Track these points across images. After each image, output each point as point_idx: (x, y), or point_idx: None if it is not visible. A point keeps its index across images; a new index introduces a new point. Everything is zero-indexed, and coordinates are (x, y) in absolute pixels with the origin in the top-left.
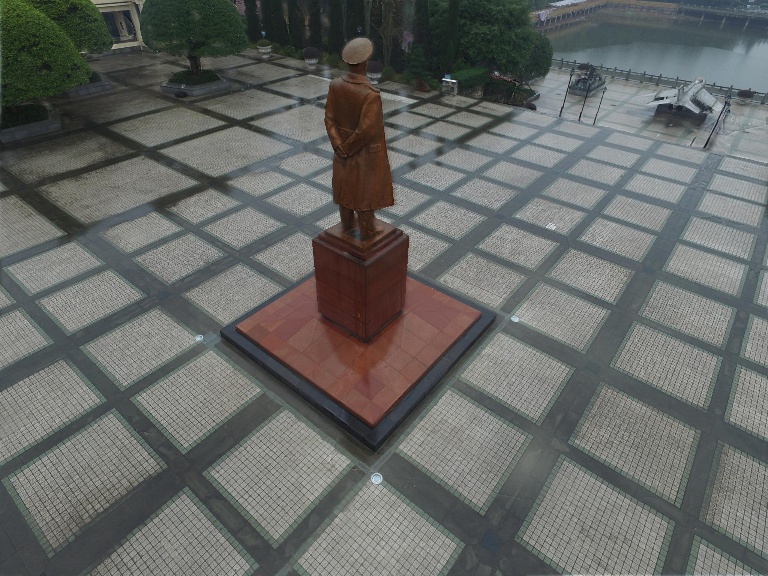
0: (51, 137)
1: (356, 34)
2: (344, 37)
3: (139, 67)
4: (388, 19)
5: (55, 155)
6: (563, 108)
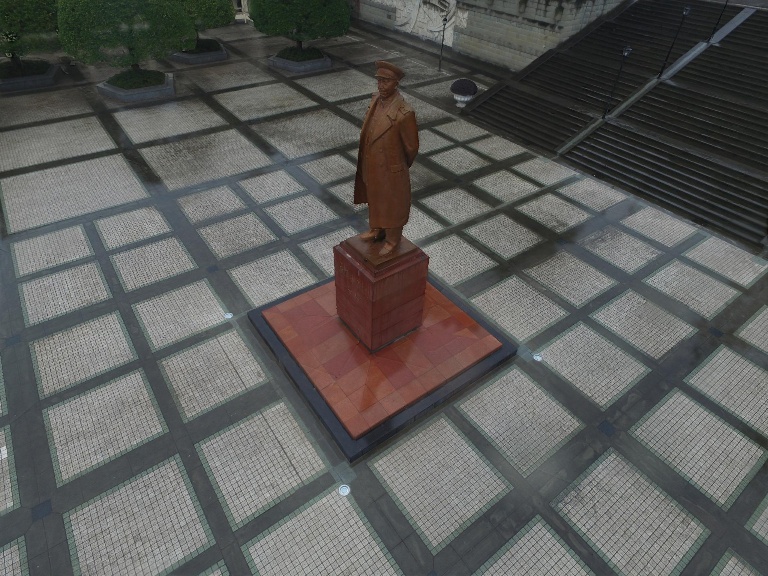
0: None
1: None
2: None
3: None
4: None
5: None
6: None
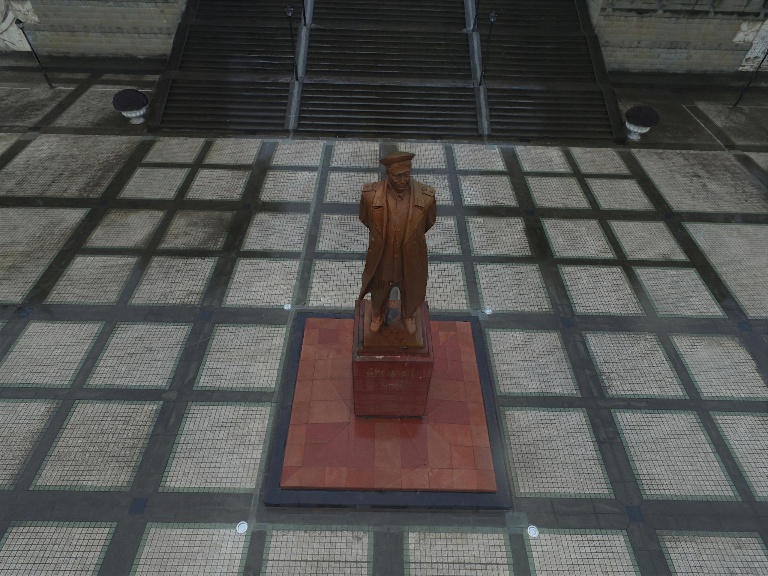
0: None
1: None
2: None
3: None
4: None
5: None
6: None
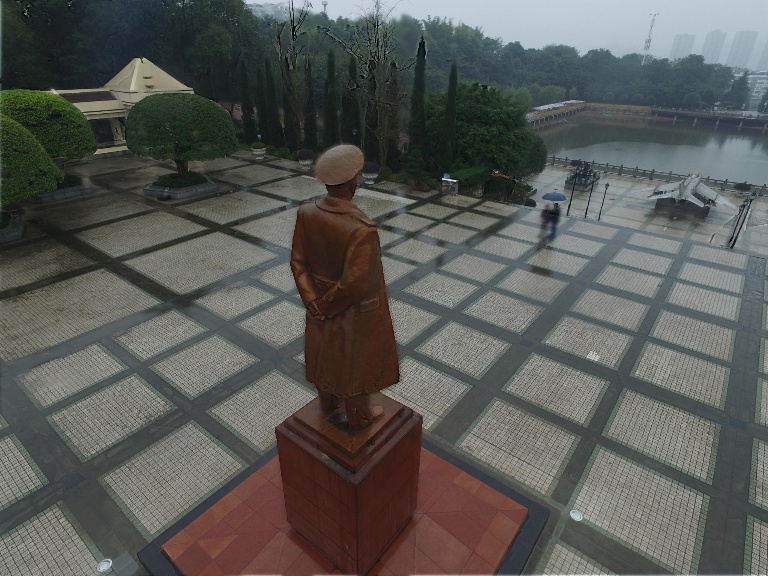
0: (6, 247)
1: (351, 136)
2: (339, 139)
3: (127, 170)
4: (384, 122)
5: (1, 269)
6: (570, 206)
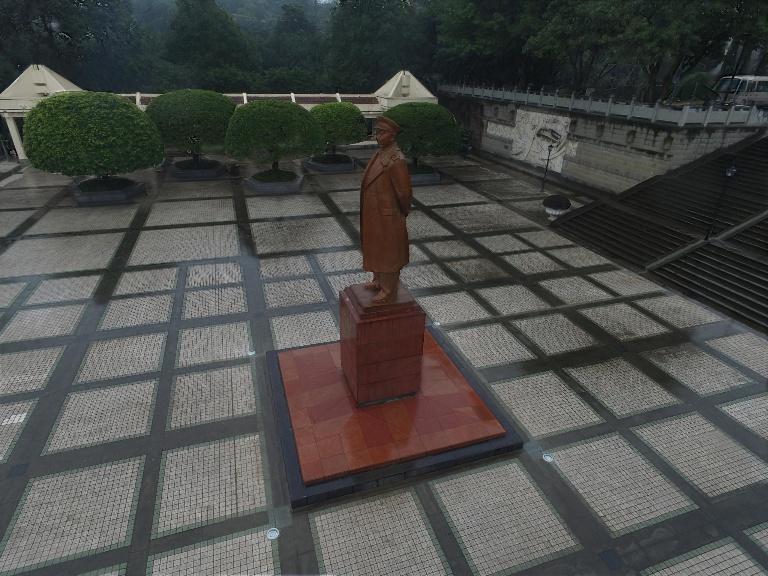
0: None
1: None
2: None
3: None
4: None
5: None
6: None
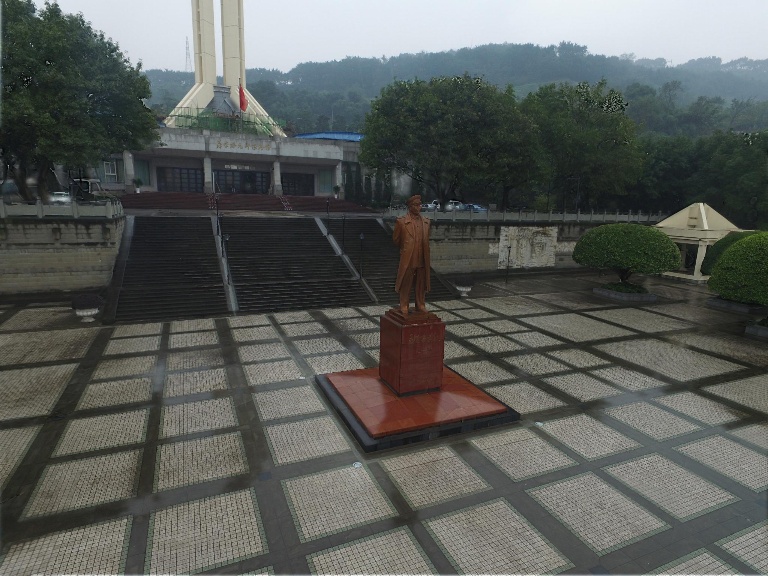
0: None
1: None
2: None
3: None
4: None
5: (727, 343)
6: None
